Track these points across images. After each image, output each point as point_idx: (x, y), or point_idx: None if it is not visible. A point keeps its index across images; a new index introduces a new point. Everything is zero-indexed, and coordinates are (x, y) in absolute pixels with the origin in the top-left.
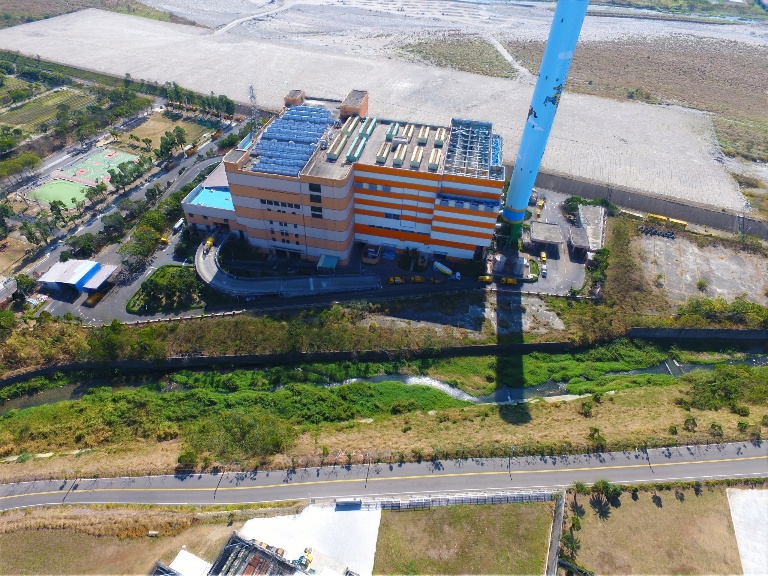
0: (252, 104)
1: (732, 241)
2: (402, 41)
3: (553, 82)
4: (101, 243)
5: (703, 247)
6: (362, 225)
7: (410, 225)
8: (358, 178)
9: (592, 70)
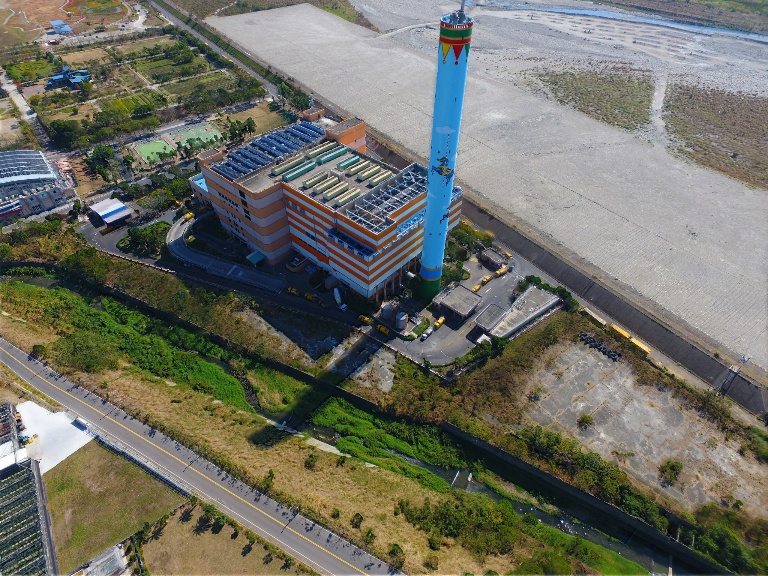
0: None
1: (696, 394)
2: (548, 68)
3: None
4: (143, 193)
5: (642, 384)
6: (295, 236)
7: (323, 249)
8: (286, 196)
9: (760, 140)
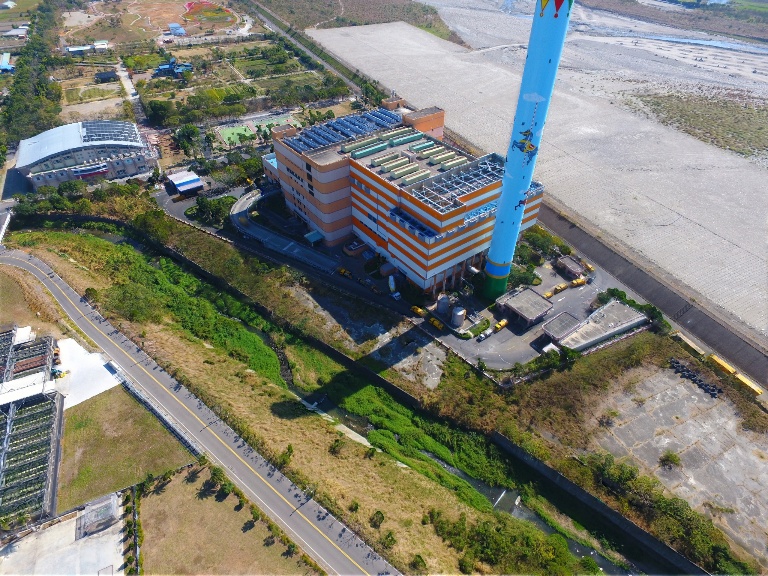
0: None
1: None
2: (651, 90)
3: (520, 125)
4: (219, 169)
5: (749, 429)
6: (357, 219)
7: (384, 232)
8: (352, 173)
9: None
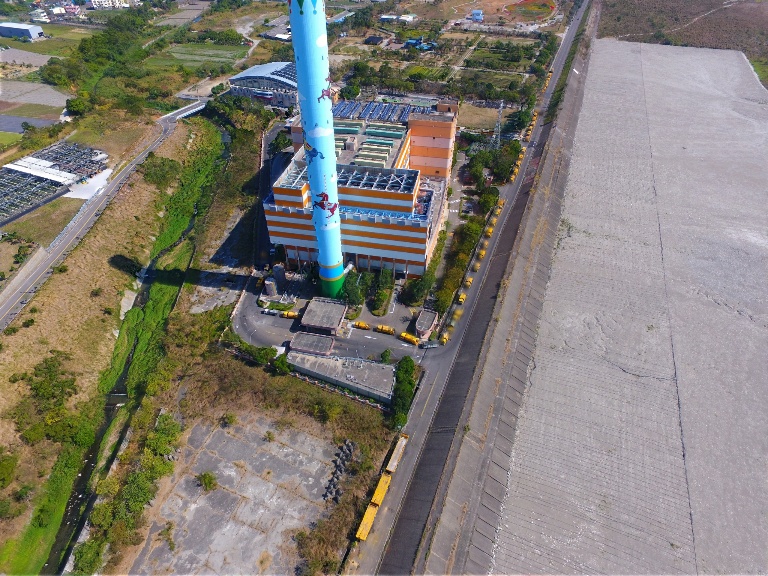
0: (498, 118)
1: None
2: None
3: None
4: None
5: (297, 541)
6: None
7: None
8: None
9: None
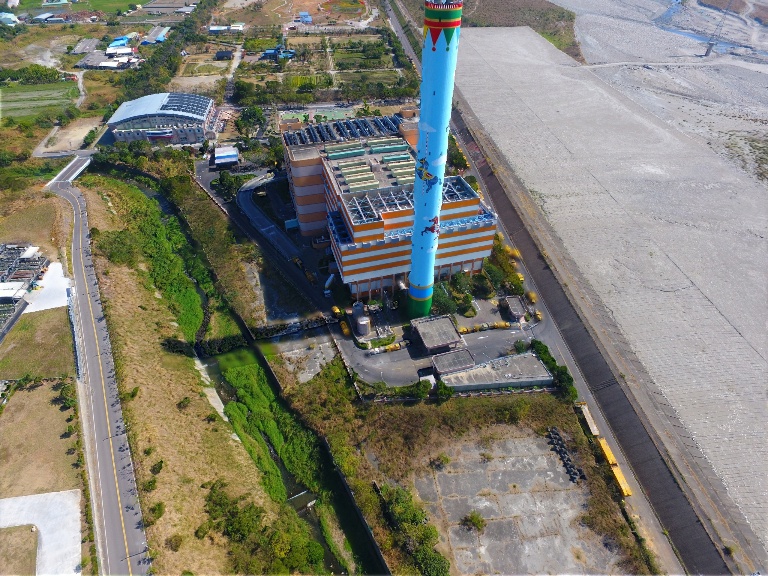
0: None
1: None
2: None
3: None
4: None
5: (587, 526)
6: None
7: None
8: None
9: None
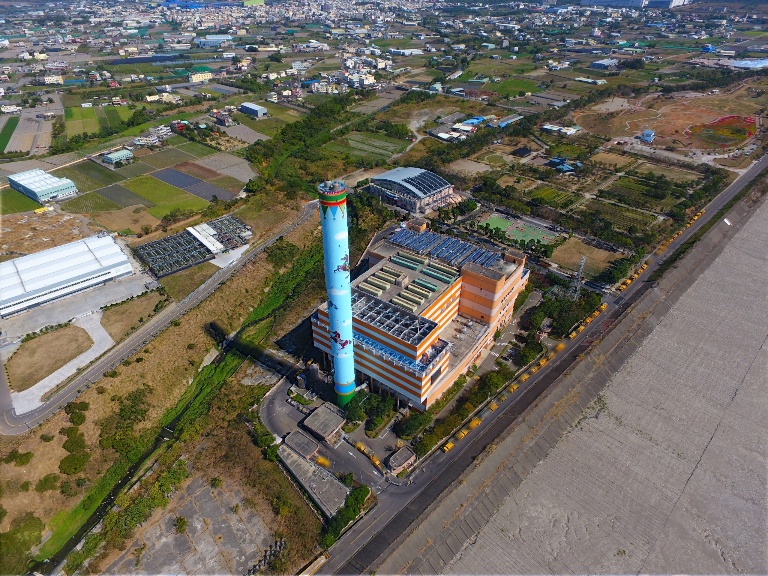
0: (579, 271)
1: None
2: None
3: None
4: None
5: None
6: None
7: None
8: None
9: None
